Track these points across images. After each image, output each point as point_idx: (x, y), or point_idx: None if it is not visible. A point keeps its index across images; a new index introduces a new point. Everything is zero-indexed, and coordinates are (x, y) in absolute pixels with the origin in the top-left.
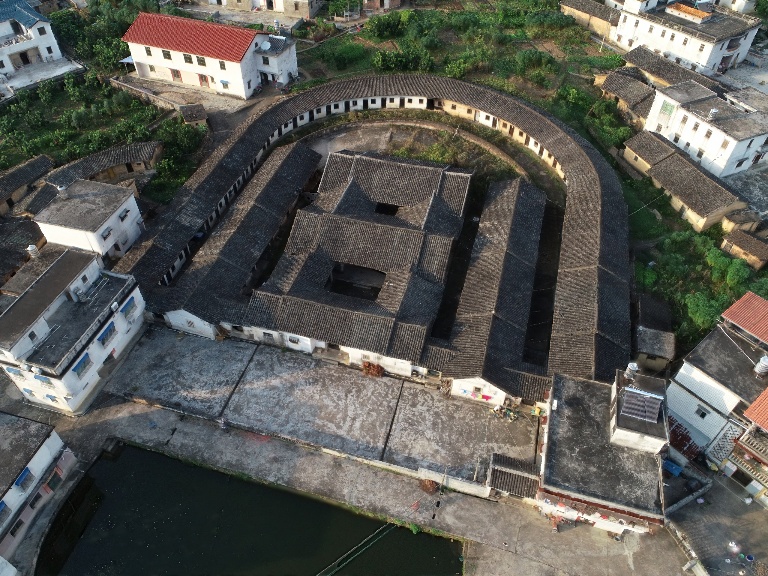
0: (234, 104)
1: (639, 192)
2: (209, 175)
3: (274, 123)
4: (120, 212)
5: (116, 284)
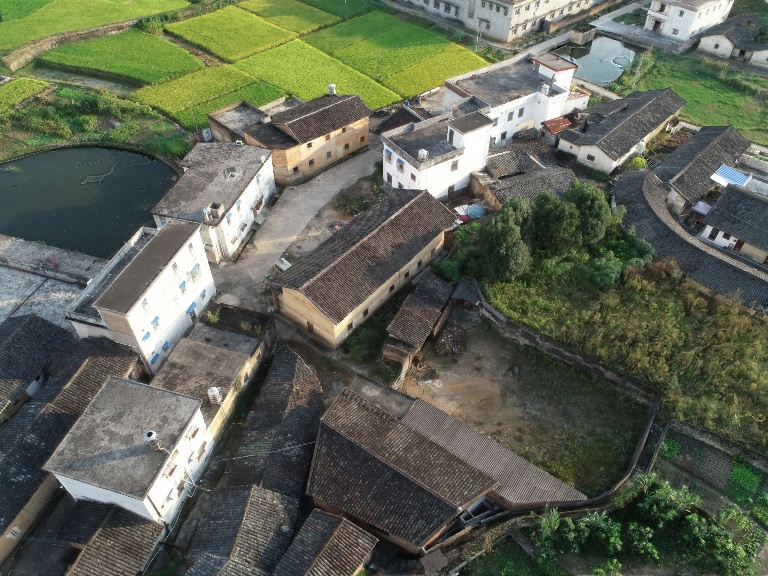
0: None
1: None
2: None
3: None
4: None
5: (91, 314)
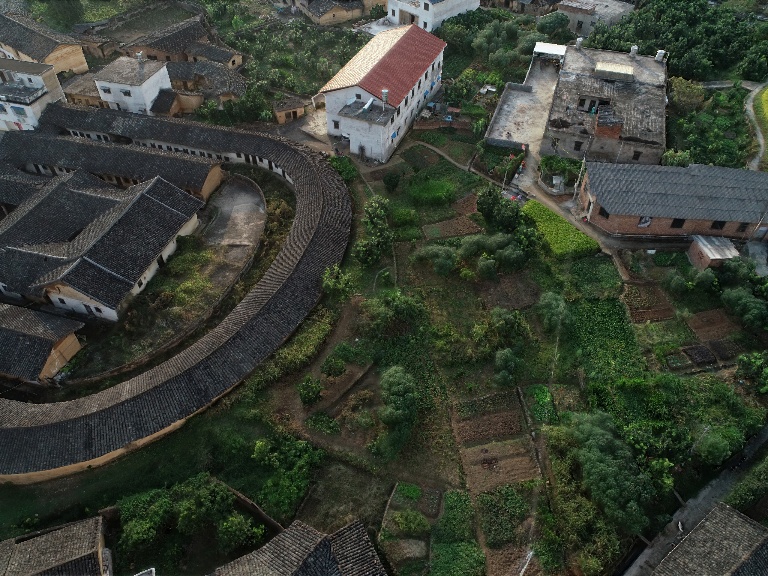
0: (320, 128)
1: (1, 532)
2: (171, 123)
3: (262, 151)
4: (124, 88)
5: None
